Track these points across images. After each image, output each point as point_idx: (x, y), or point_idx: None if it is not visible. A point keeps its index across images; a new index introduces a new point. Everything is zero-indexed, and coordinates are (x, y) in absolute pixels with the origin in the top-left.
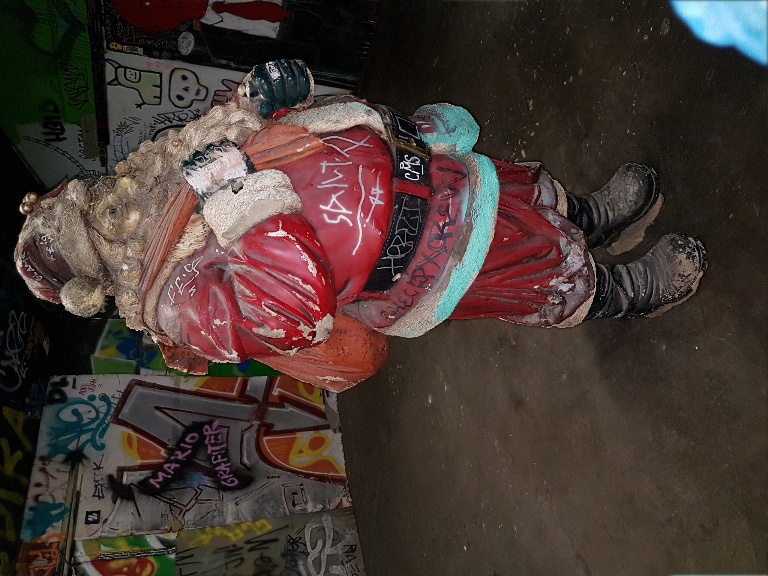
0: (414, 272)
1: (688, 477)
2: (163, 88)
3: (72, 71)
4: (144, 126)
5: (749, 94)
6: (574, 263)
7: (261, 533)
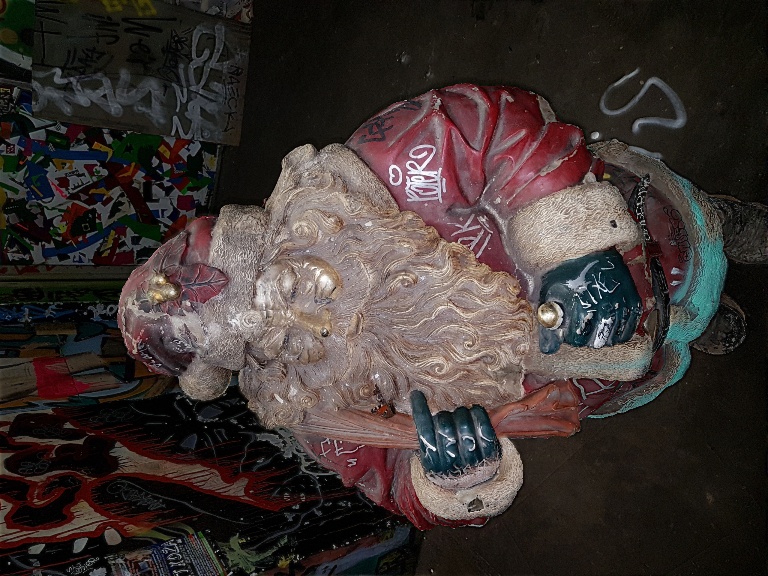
0: None
1: None
2: None
3: None
4: None
5: None
6: None
7: (143, 16)
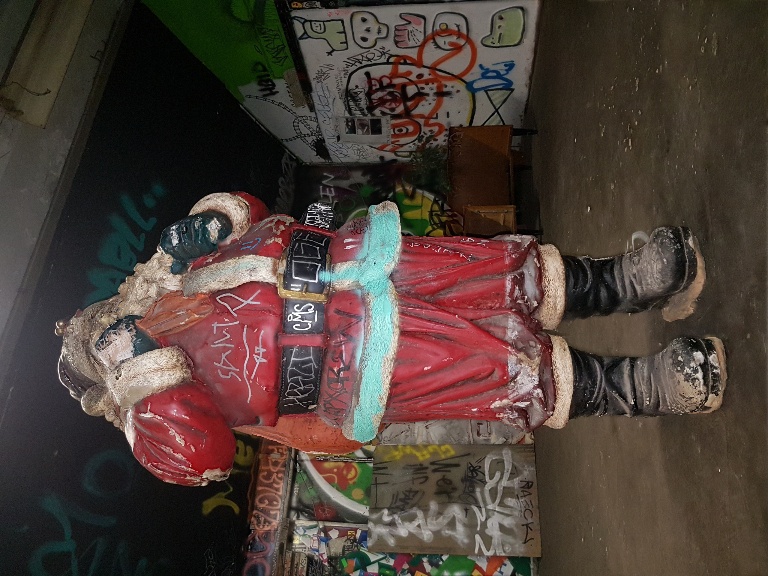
0: (325, 405)
1: None
2: (347, 33)
3: (269, 33)
4: (338, 71)
5: (765, 187)
6: (523, 384)
7: (445, 457)
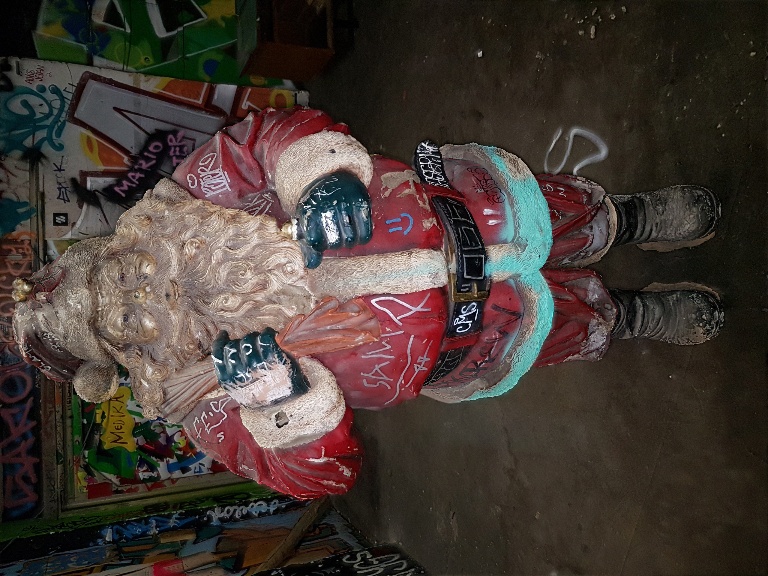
0: None
1: (614, 451)
2: None
3: None
4: None
5: None
6: (595, 342)
7: None
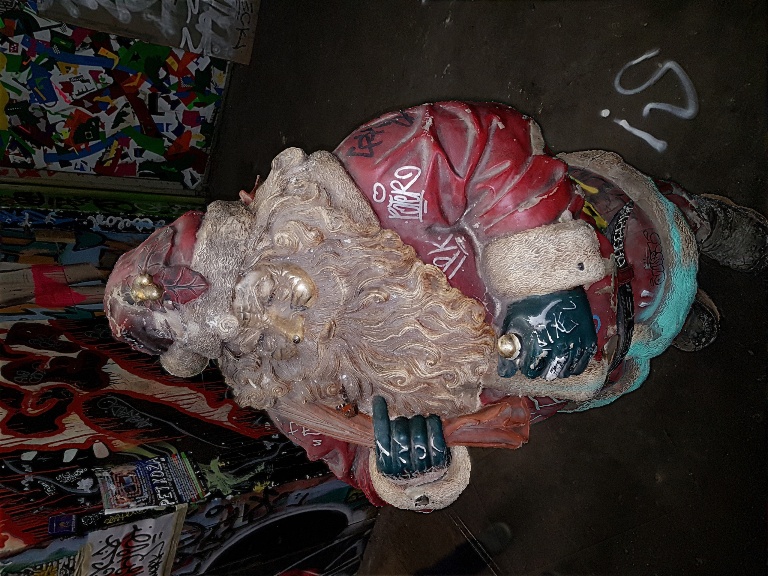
0: None
1: None
2: None
3: None
4: None
5: None
6: None
7: None
